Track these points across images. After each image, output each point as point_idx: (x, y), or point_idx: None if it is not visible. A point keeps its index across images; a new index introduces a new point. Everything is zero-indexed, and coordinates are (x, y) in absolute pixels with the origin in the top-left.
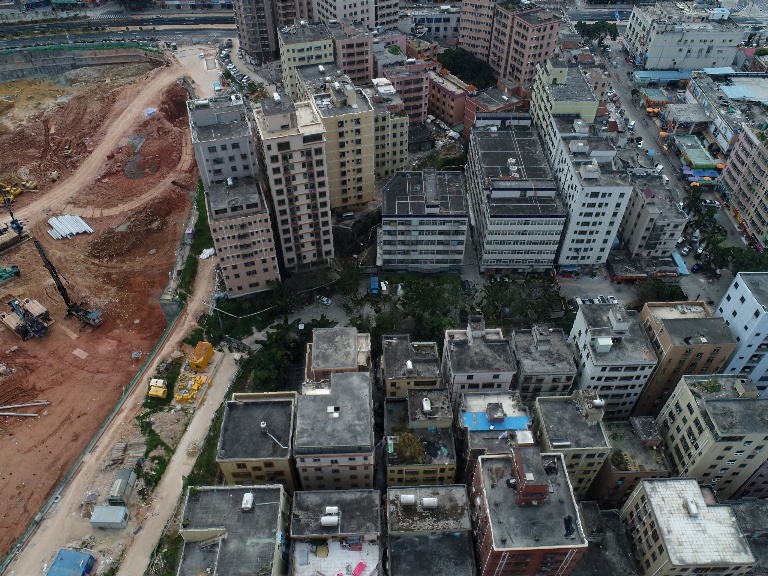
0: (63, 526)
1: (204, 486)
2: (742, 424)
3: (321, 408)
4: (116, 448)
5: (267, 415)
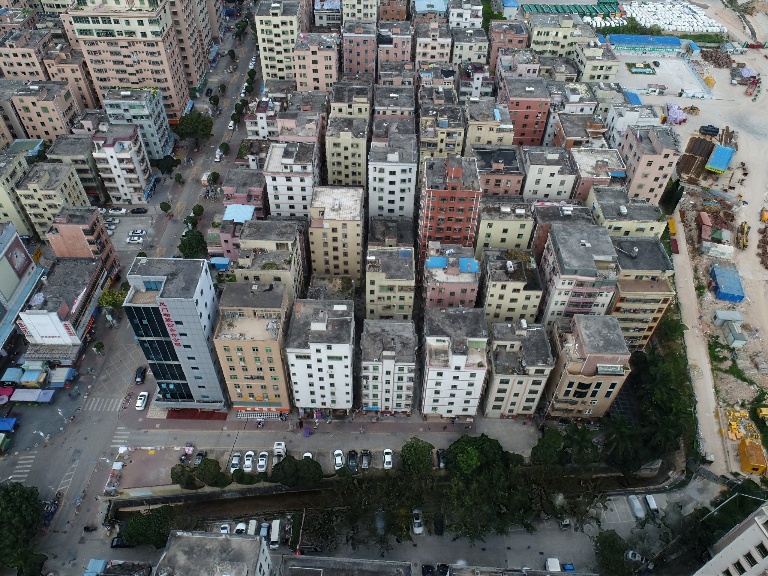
0: (759, 320)
1: (657, 221)
2: (276, 227)
3: (596, 246)
4: (765, 364)
5: (637, 265)
